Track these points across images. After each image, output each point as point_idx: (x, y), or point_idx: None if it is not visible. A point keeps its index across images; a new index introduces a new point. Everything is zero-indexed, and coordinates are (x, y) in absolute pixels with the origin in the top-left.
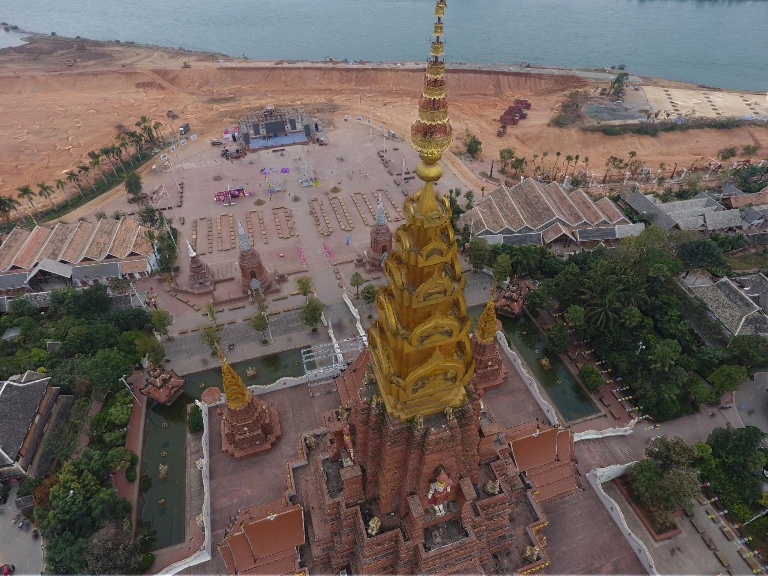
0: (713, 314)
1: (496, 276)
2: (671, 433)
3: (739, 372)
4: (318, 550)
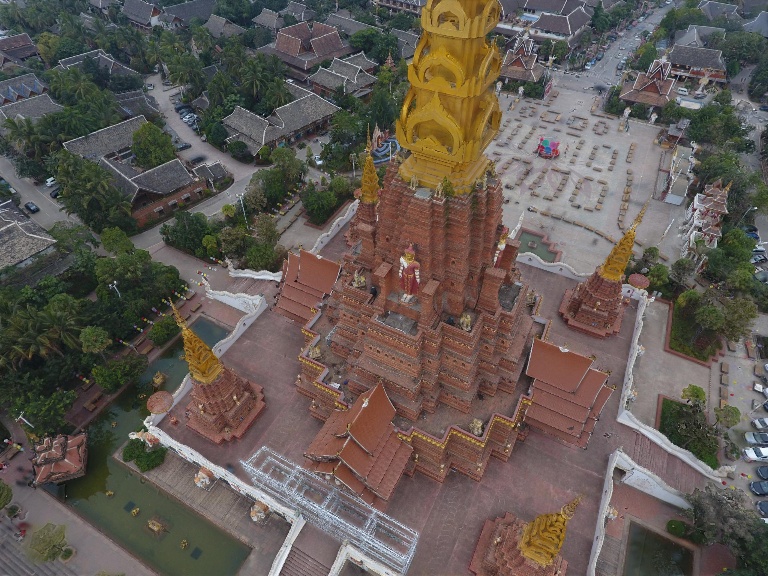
0: (20, 263)
1: (4, 500)
2: (191, 275)
3: (111, 232)
4: (531, 329)
